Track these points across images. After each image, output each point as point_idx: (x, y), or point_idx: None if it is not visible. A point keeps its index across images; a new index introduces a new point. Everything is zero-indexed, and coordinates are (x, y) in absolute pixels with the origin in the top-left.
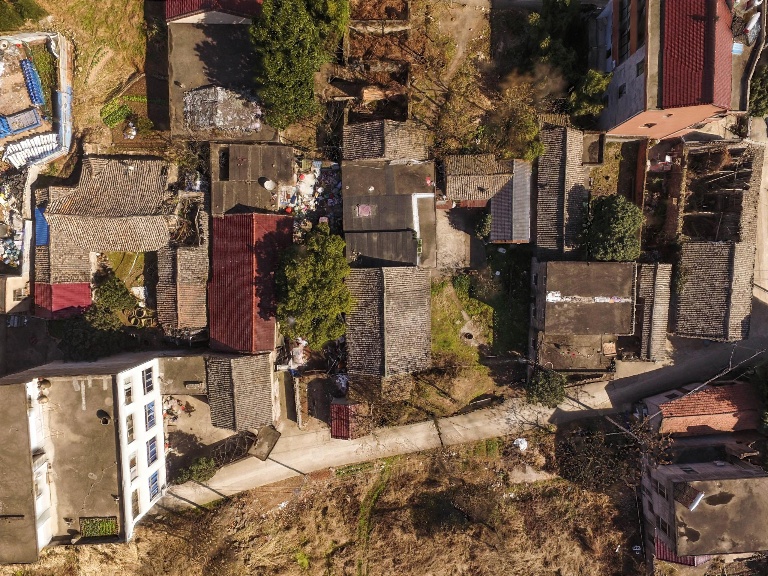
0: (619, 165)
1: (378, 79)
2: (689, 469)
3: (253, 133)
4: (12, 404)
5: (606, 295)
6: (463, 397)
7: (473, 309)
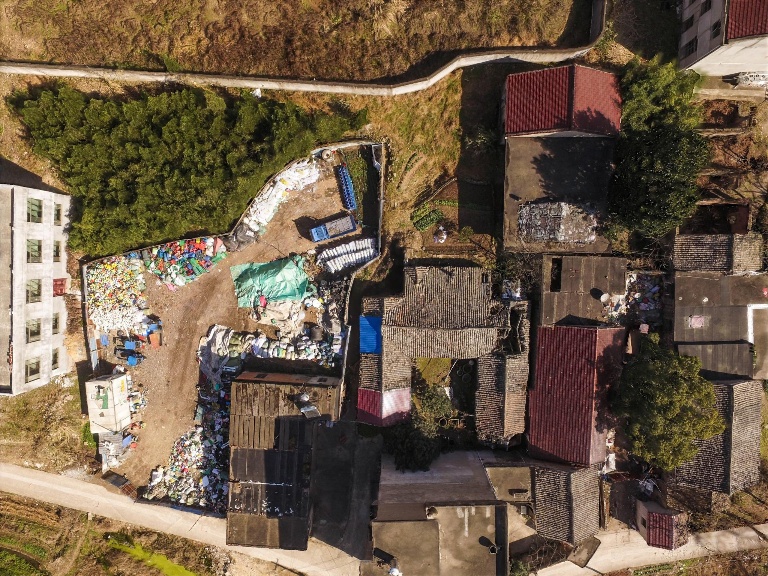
0: None
1: (697, 182)
2: None
3: (587, 245)
4: (424, 539)
5: None
6: None
7: None
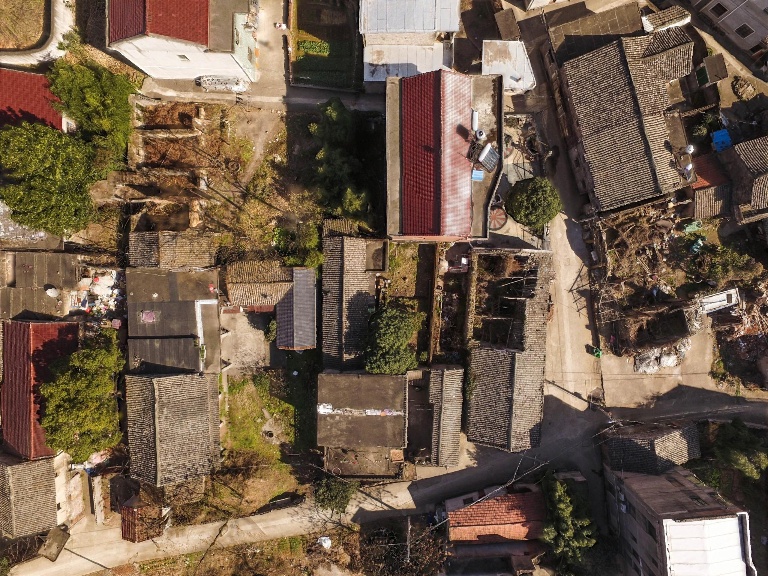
0: (417, 266)
1: (175, 182)
2: None
3: (39, 241)
4: None
5: (378, 408)
6: (261, 497)
7: (274, 407)
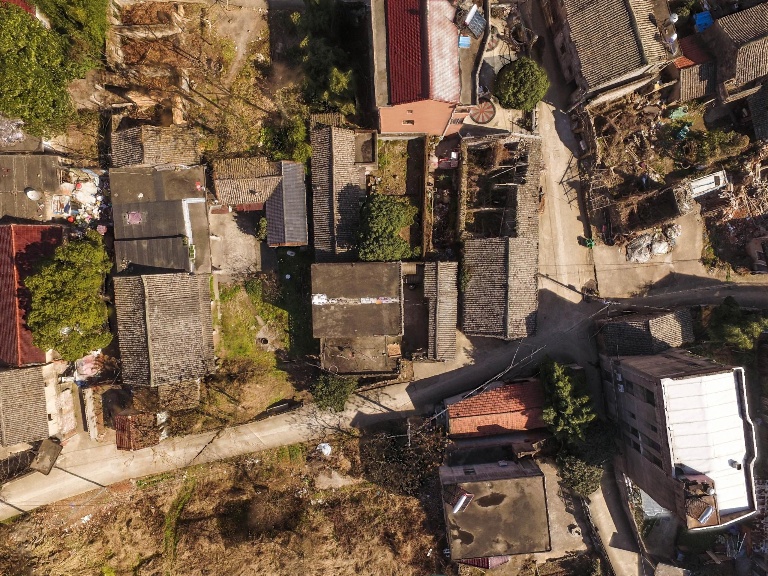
0: (406, 163)
1: (156, 84)
2: (472, 470)
3: (17, 143)
4: None
5: (373, 296)
6: (258, 403)
7: (267, 314)
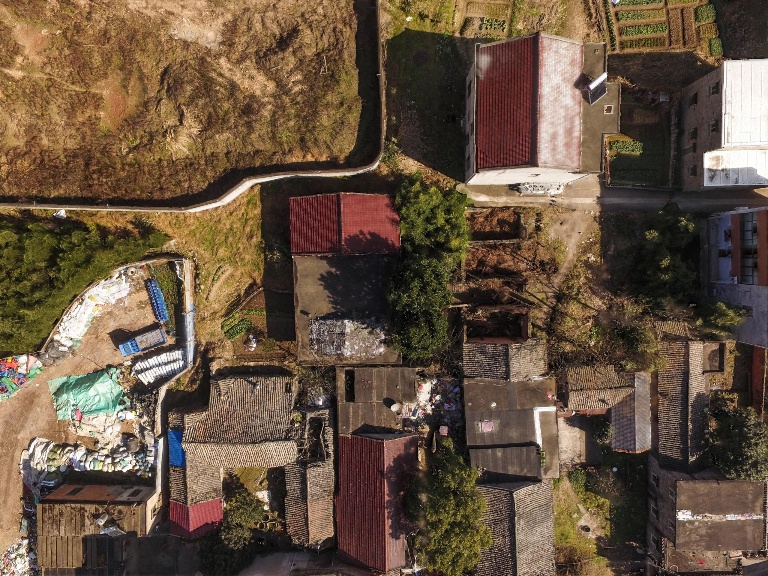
0: (734, 359)
1: (490, 286)
2: None
3: (377, 356)
4: None
5: (737, 512)
6: None
7: (590, 502)
